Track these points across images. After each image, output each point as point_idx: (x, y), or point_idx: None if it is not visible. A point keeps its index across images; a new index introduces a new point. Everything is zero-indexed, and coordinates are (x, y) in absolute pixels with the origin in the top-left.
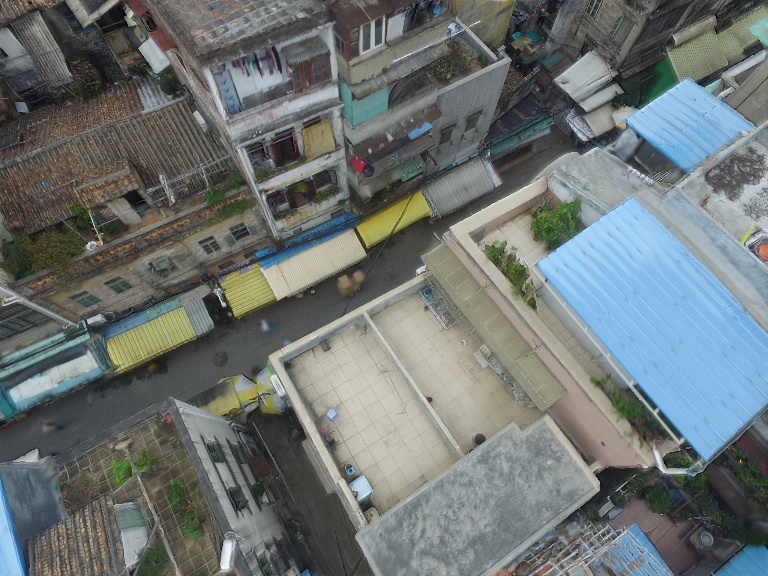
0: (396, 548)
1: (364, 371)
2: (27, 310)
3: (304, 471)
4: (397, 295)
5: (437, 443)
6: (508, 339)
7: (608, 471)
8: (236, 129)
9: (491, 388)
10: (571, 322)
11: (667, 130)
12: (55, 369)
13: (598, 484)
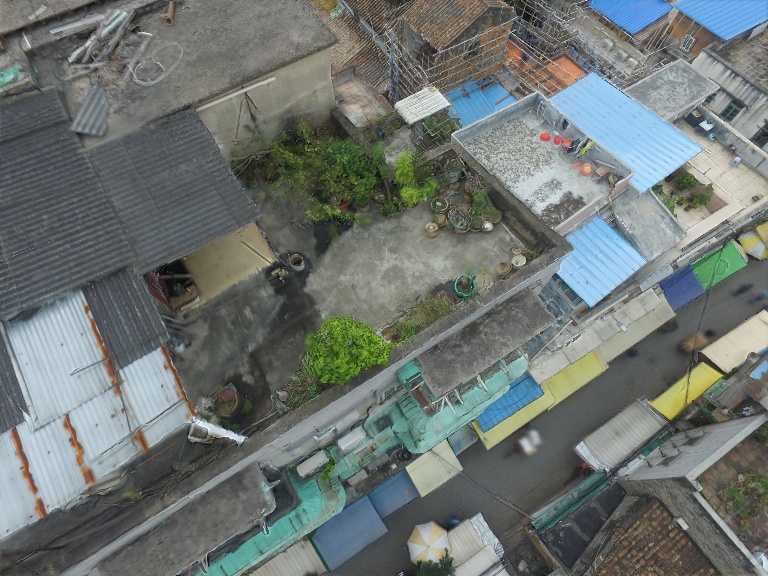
0: (697, 84)
1: None
2: None
3: None
4: None
5: None
6: None
7: None
8: None
9: None
10: None
11: (613, 251)
12: None
13: None
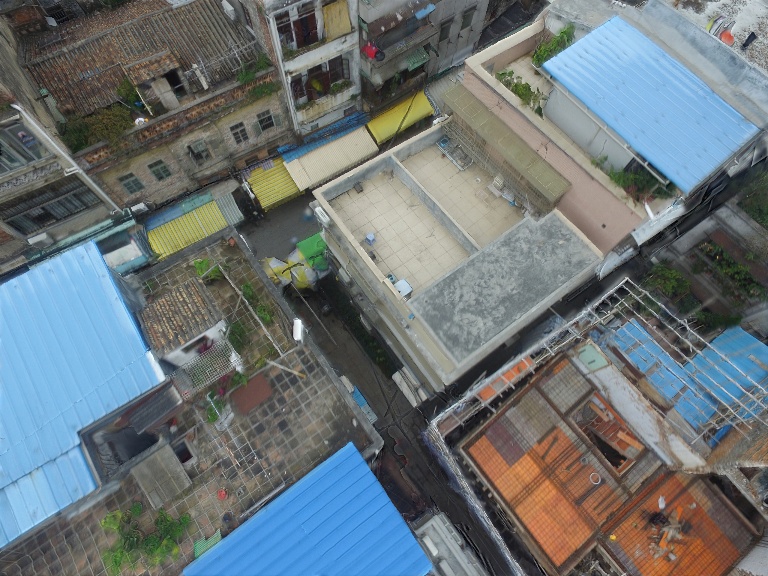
0: (440, 310)
1: (394, 207)
2: (83, 187)
3: (336, 342)
4: (418, 141)
5: (463, 257)
6: (519, 151)
7: (608, 280)
8: None
9: (505, 213)
10: (572, 127)
11: None
12: None
13: (602, 255)
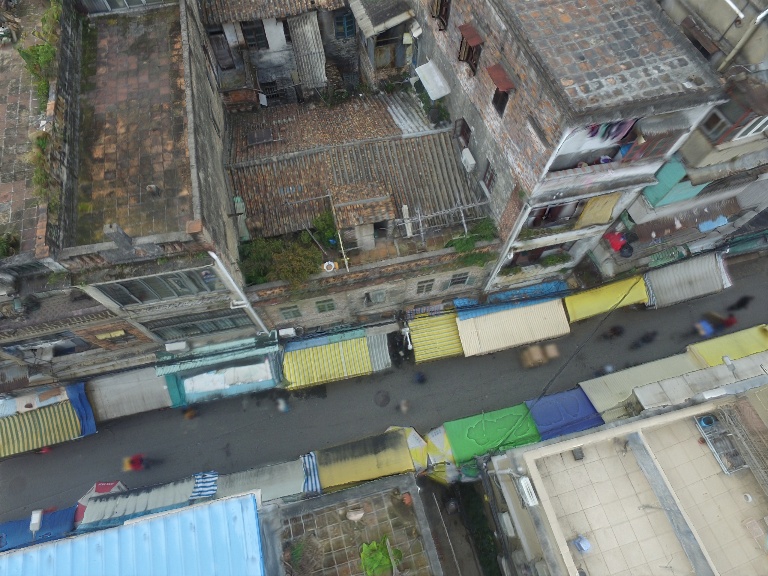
0: None
1: (621, 498)
2: (242, 313)
3: None
4: (679, 419)
5: None
6: None
7: None
8: (543, 187)
9: None
10: None
11: None
12: (231, 370)
13: None
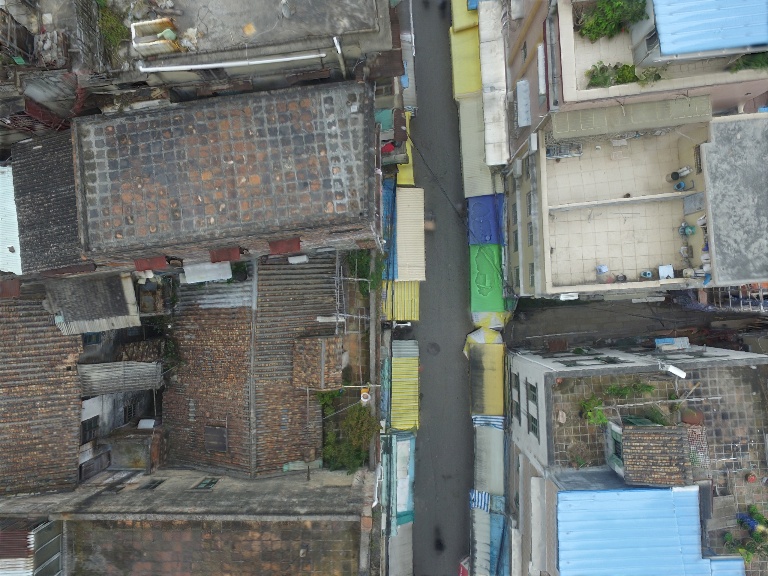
0: (736, 264)
1: (581, 232)
2: None
3: (550, 323)
4: None
5: (658, 207)
6: (652, 112)
7: None
8: None
9: (641, 148)
10: None
11: None
12: (397, 473)
13: None
